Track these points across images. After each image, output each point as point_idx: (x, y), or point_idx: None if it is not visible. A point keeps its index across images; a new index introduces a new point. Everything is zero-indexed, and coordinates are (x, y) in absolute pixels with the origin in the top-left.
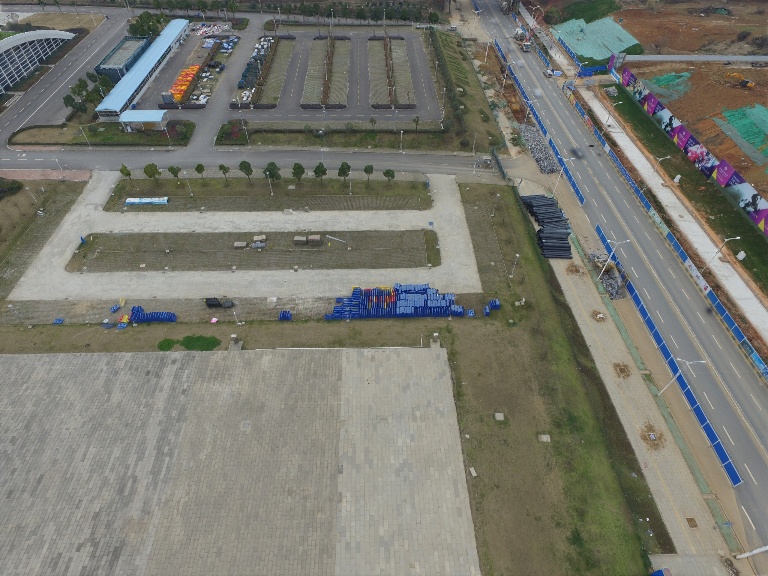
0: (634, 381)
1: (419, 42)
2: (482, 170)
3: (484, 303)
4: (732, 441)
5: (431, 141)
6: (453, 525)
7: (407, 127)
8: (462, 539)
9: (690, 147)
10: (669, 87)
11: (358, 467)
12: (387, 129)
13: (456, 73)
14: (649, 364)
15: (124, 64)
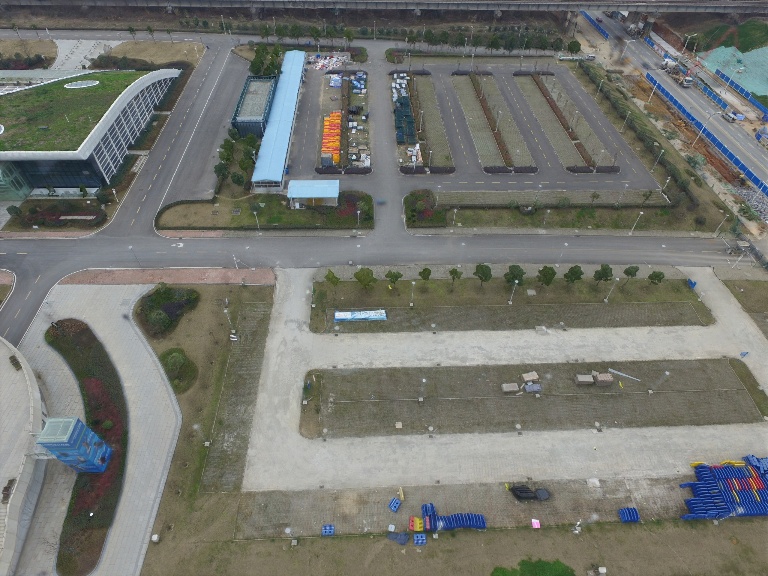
0: None
1: (572, 78)
2: (736, 259)
3: None
4: None
5: (661, 218)
6: None
7: (625, 199)
8: None
9: None
10: None
11: None
12: (607, 204)
13: (635, 120)
14: None
15: (264, 115)
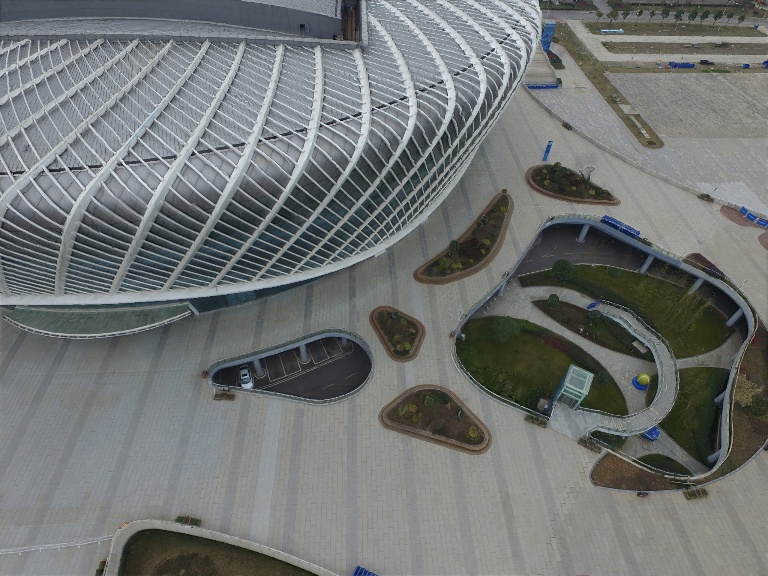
0: None
1: None
2: None
3: None
4: None
5: (736, 11)
6: None
7: None
8: None
9: None
10: None
11: None
12: (709, 4)
13: None
14: None
15: None
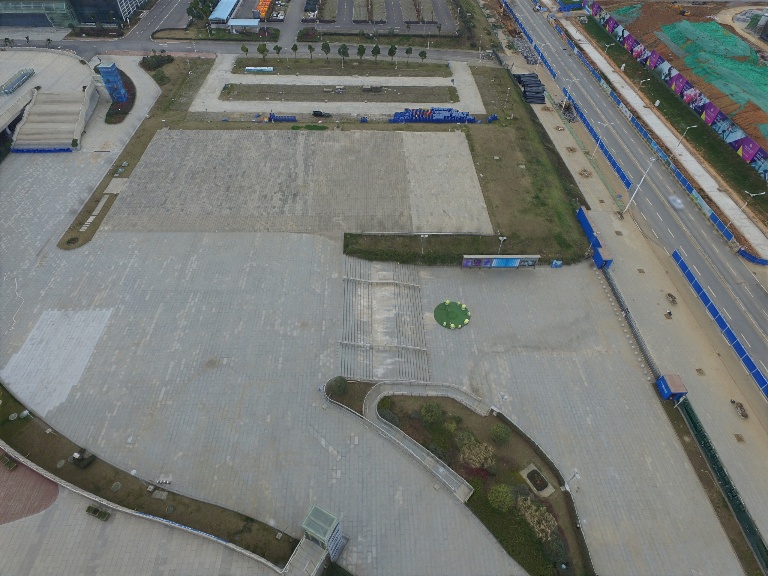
0: (578, 154)
1: None
2: (486, 60)
3: (487, 118)
4: (632, 176)
5: (449, 43)
6: (471, 191)
7: (432, 34)
8: (476, 195)
9: (634, 48)
10: (626, 15)
11: (418, 172)
12: (418, 34)
13: (466, 6)
14: (588, 148)
15: None
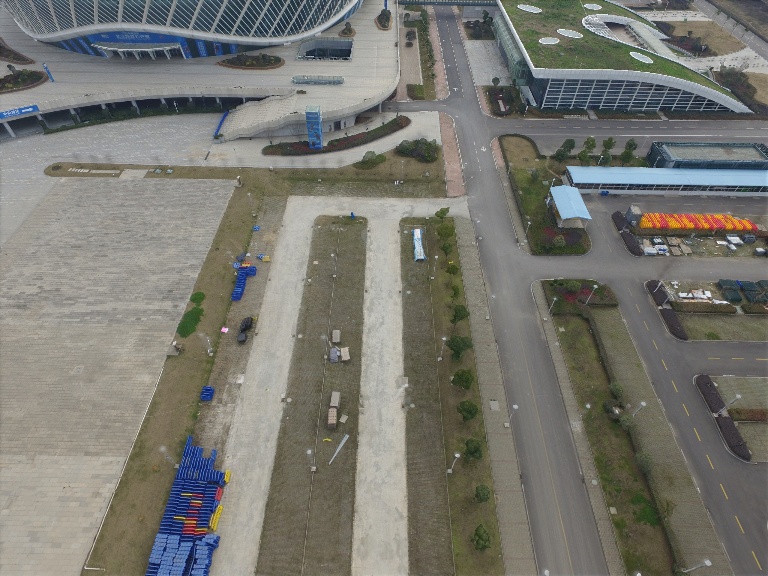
0: None
1: None
2: None
3: None
4: None
5: None
6: None
7: None
8: None
9: None
10: None
11: None
12: (678, 549)
13: None
14: None
15: (681, 159)
